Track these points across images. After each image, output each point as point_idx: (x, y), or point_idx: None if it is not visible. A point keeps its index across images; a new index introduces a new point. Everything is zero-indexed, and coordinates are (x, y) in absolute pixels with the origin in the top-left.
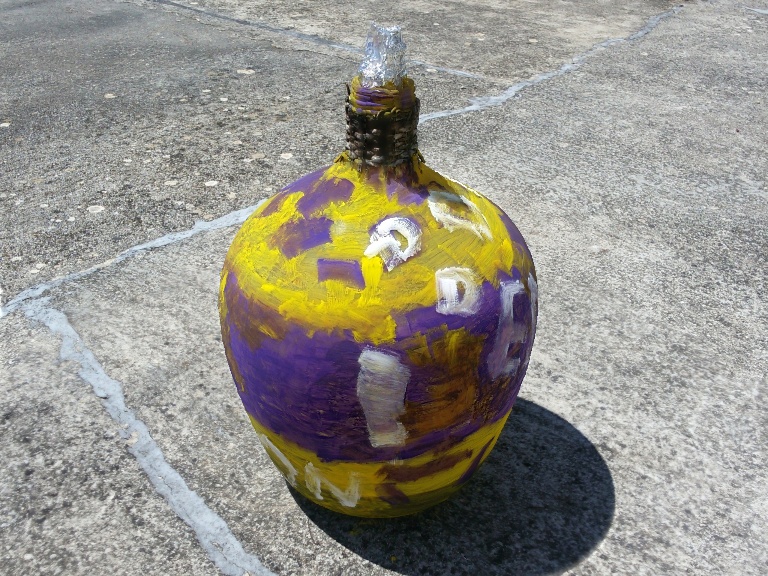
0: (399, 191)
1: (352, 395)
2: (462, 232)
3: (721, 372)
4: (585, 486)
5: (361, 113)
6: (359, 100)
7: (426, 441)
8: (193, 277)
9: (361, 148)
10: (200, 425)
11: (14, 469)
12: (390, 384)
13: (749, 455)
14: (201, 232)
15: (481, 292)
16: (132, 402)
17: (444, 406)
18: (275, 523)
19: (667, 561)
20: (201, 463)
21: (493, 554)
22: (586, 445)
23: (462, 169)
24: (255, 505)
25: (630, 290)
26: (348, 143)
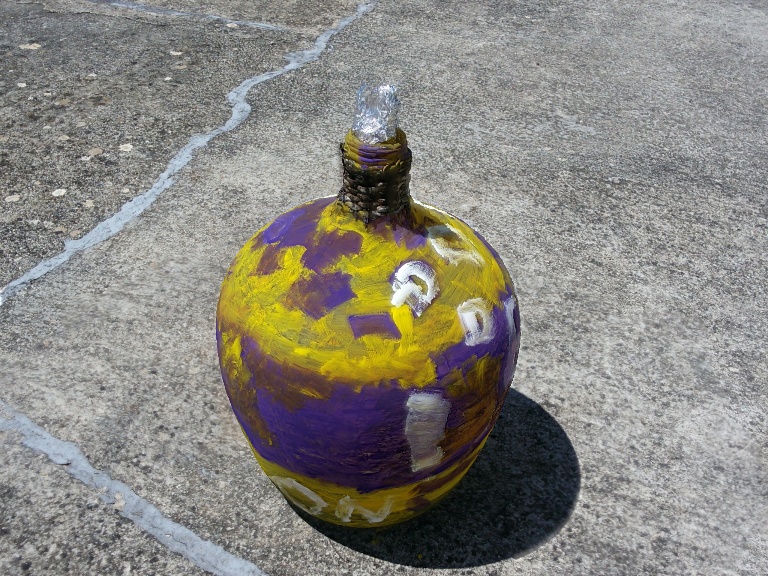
0: (405, 235)
1: (400, 435)
2: (464, 263)
3: (611, 312)
4: (547, 445)
5: (367, 169)
6: (364, 157)
7: (456, 455)
8: (94, 307)
9: (366, 201)
10: (181, 470)
11: (7, 567)
12: (434, 418)
13: (658, 385)
14: (77, 252)
15: (494, 317)
16: (98, 462)
17: (474, 423)
18: (301, 552)
19: (633, 496)
20: (201, 510)
21: (500, 528)
22: (533, 406)
23: (311, 138)
24: (274, 539)
25: (510, 245)
26: (348, 195)
